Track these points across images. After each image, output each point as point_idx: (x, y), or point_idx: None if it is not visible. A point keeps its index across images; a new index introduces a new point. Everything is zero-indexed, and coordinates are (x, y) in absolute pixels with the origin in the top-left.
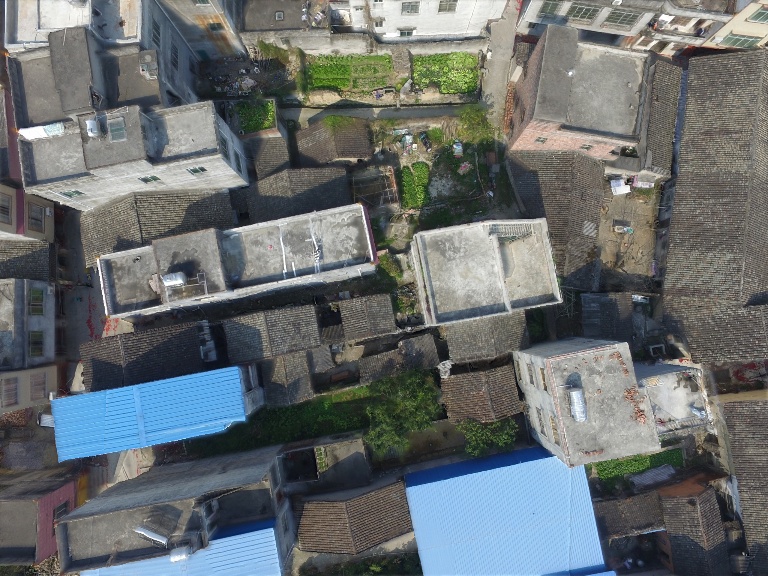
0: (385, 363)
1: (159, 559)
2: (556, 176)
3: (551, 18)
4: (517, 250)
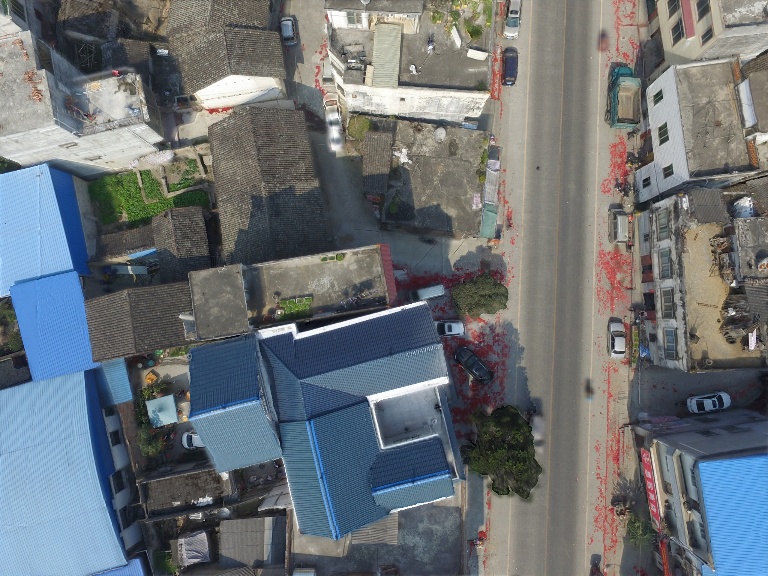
0: None
1: None
2: None
3: None
4: None
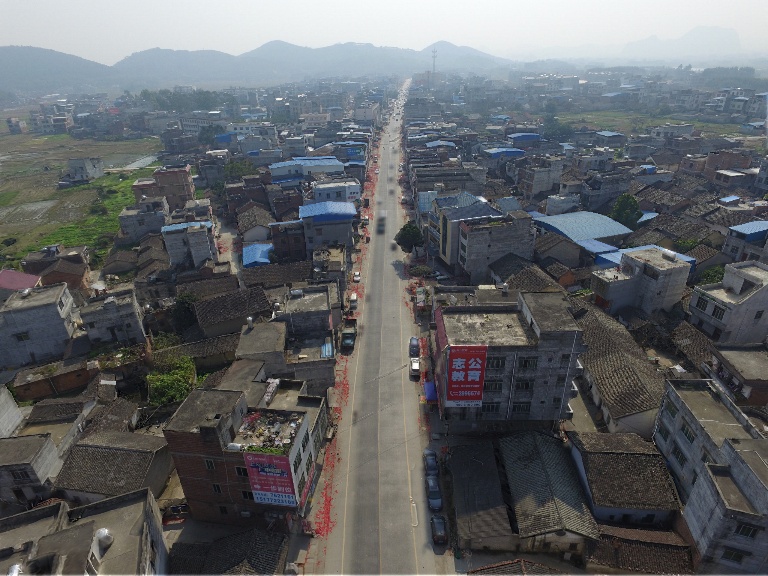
0: None
1: None
2: None
3: None
4: None
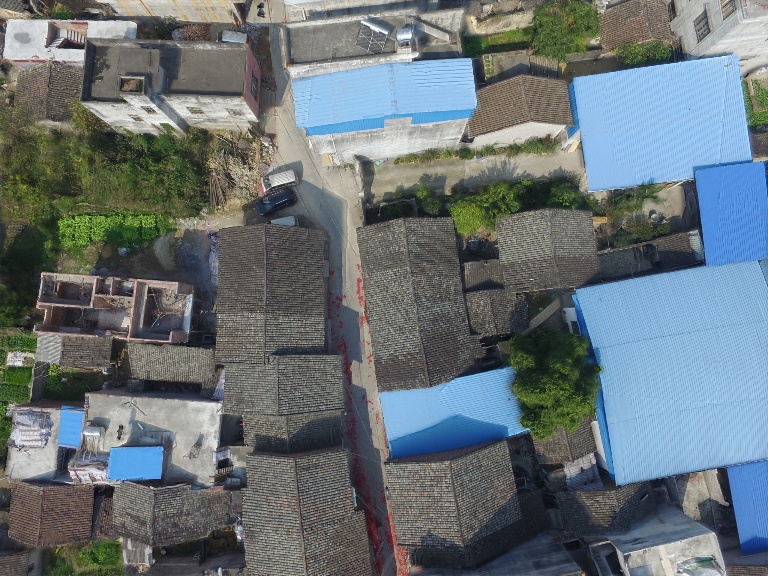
0: (545, 1)
1: (369, 73)
2: None
3: None
4: None
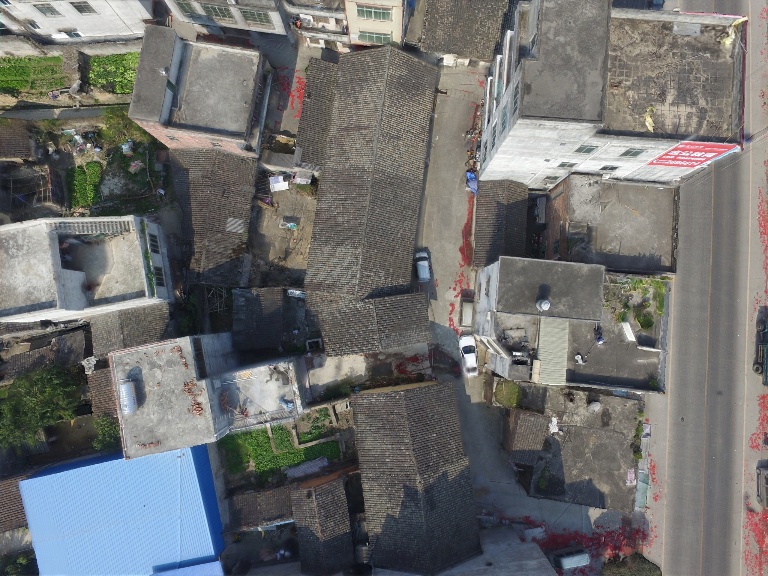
0: (36, 360)
1: None
2: (201, 174)
3: (198, 18)
4: (117, 247)
